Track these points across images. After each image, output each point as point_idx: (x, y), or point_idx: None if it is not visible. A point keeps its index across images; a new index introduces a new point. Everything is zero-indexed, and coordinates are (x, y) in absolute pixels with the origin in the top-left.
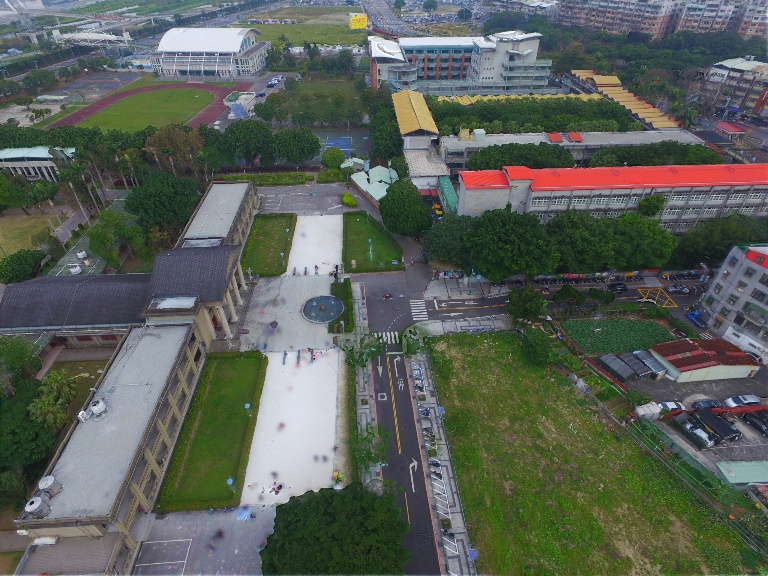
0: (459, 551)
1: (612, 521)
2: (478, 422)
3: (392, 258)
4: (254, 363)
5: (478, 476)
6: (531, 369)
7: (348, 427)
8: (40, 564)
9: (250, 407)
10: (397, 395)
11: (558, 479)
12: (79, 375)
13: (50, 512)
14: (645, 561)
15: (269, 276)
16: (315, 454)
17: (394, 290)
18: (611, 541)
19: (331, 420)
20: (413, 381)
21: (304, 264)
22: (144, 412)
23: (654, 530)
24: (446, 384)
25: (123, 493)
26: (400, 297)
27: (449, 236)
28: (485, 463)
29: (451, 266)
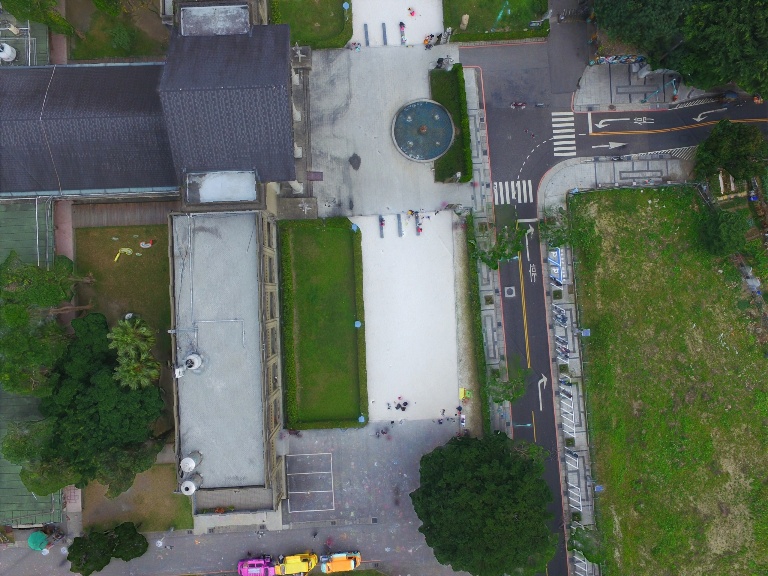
0: (579, 467)
1: (726, 441)
2: (619, 331)
3: (527, 1)
4: (343, 235)
5: (609, 398)
6: (699, 254)
7: (471, 335)
8: (209, 498)
9: (353, 304)
10: (528, 290)
11: (688, 400)
12: (119, 252)
13: (203, 480)
14: (741, 476)
15: (327, 48)
16: (437, 367)
17: (529, 87)
18: (718, 460)
19: (451, 323)
20: (548, 269)
21: (379, 13)
22: (249, 362)
23: (761, 450)
24: (590, 278)
25: (267, 460)
26: (538, 106)
27: (660, 8)
28: (618, 381)
29: (631, 46)
